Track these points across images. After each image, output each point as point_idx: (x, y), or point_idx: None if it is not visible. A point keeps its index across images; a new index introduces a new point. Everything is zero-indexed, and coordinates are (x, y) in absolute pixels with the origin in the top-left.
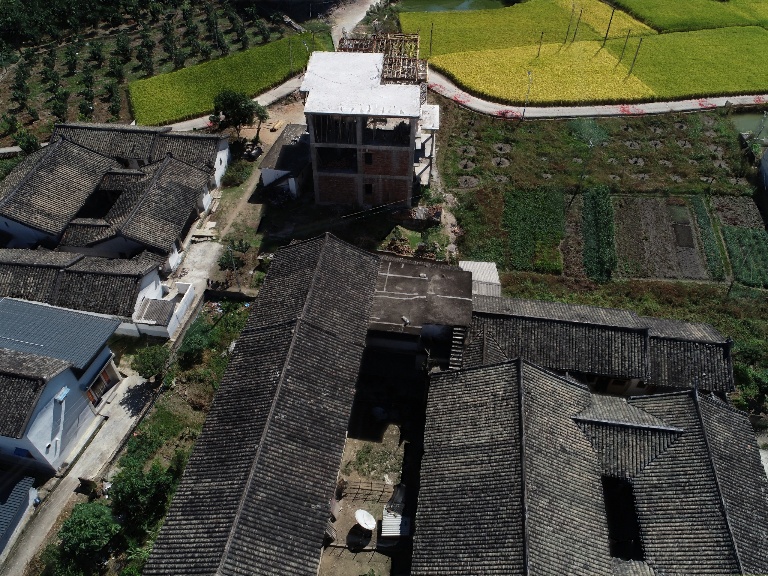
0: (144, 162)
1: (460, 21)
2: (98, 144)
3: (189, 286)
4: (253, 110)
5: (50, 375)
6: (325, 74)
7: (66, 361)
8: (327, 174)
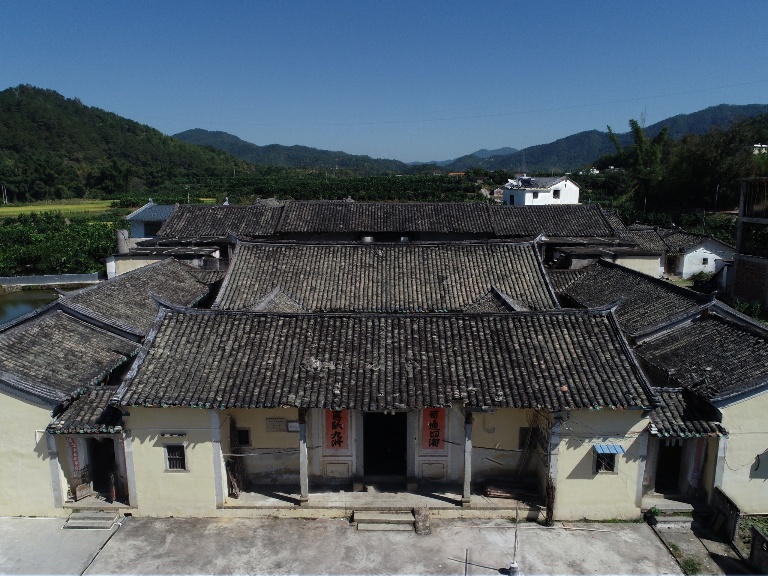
0: None
1: None
2: None
3: None
4: None
5: None
6: None
7: None
8: None
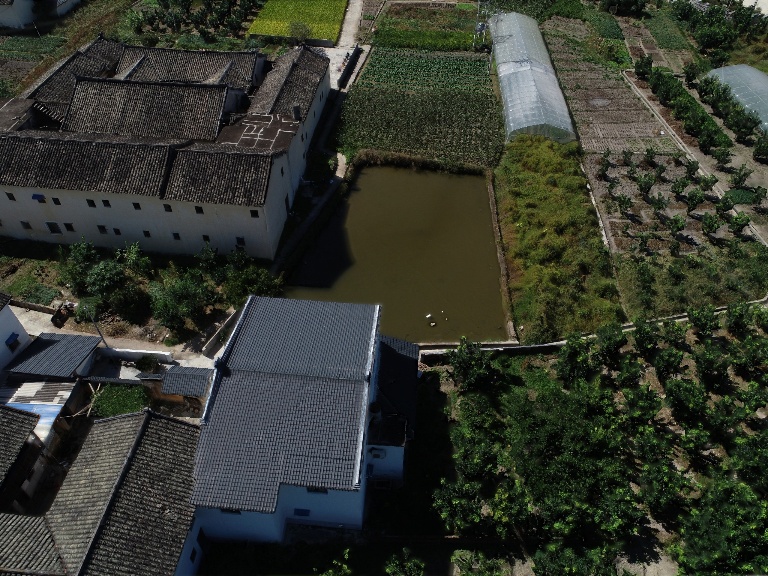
0: None
1: None
2: None
3: None
4: None
5: None
6: None
7: None
8: None
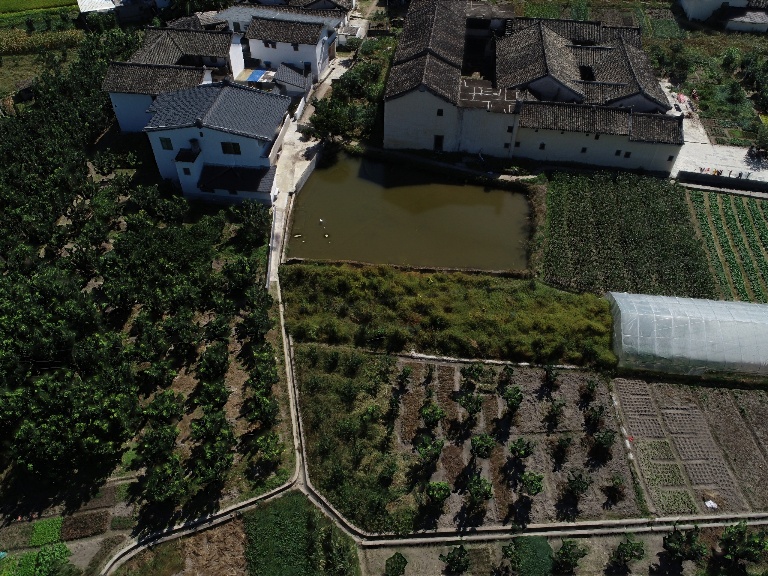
0: None
1: None
2: None
3: (359, 27)
4: None
5: None
6: None
7: None
8: None
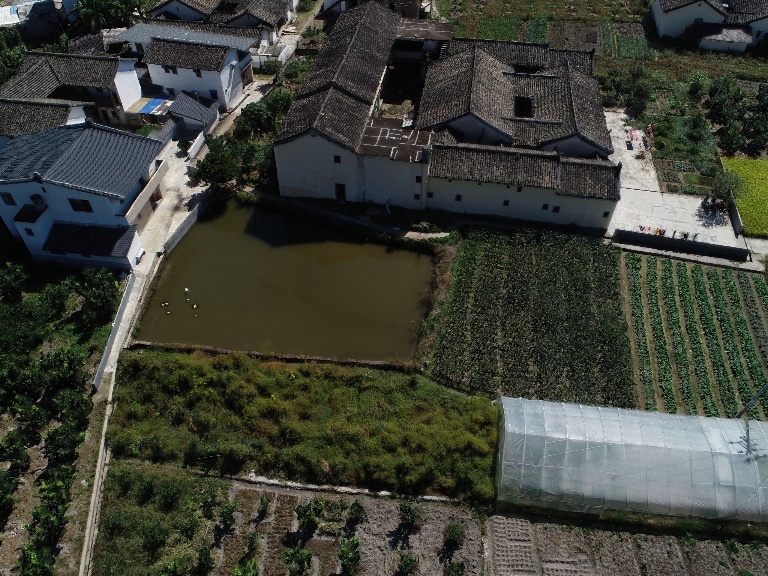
0: None
1: None
2: None
3: (286, 46)
4: None
5: (231, 47)
6: None
7: None
8: None
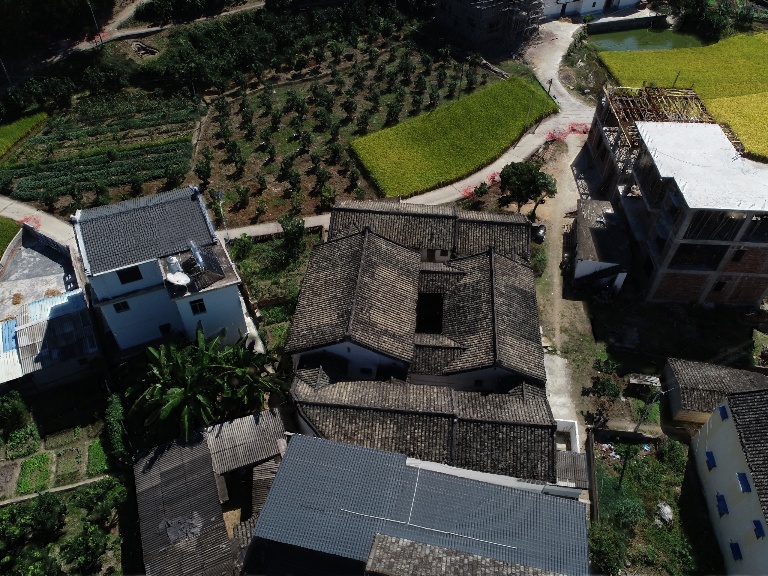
0: (435, 250)
1: (672, 62)
2: (389, 231)
3: (575, 425)
4: (548, 186)
5: None
6: (674, 153)
7: (566, 575)
8: (678, 271)
